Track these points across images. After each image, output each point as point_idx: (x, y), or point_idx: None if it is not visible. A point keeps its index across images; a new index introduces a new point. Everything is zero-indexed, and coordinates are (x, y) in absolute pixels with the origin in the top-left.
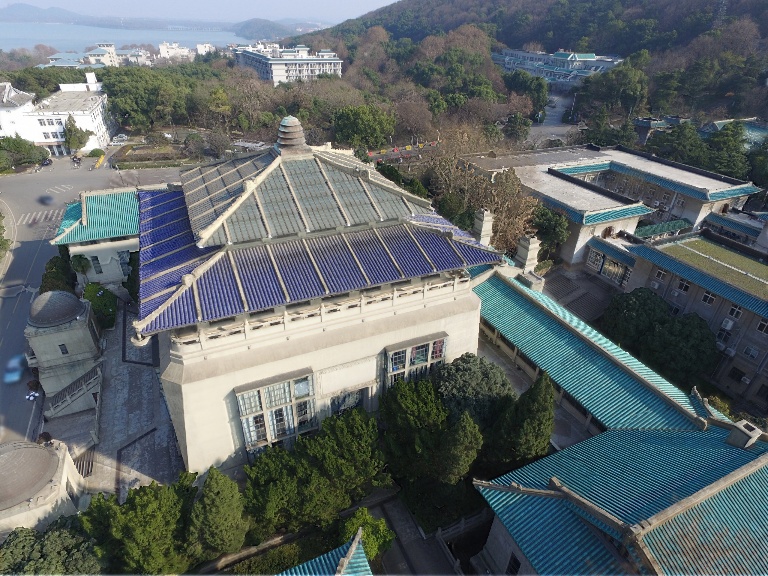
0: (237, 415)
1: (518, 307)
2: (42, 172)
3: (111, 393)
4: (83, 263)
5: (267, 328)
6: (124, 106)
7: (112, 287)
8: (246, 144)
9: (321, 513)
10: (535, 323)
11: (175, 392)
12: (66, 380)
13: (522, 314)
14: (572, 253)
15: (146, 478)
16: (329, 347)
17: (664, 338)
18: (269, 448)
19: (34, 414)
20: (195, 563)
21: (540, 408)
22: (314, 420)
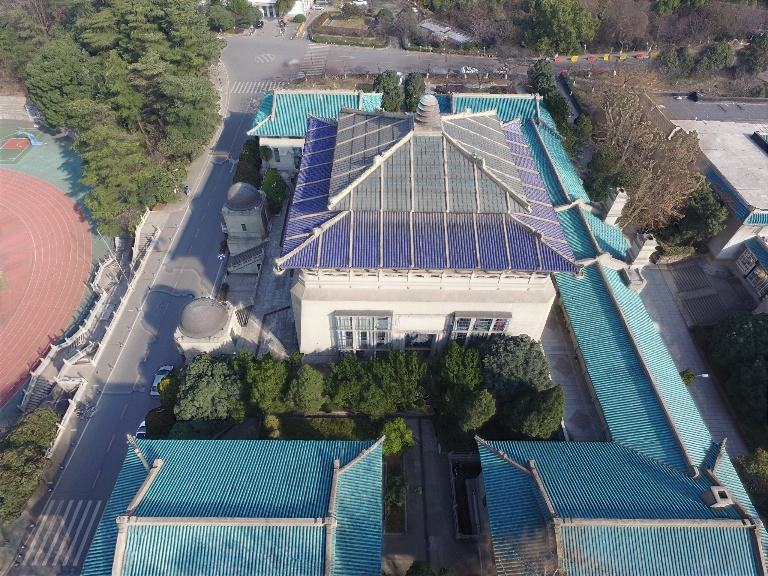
0: (335, 326)
1: (599, 305)
2: (255, 35)
3: (268, 269)
4: (267, 153)
5: (366, 277)
6: None
7: (285, 175)
8: (433, 27)
9: (372, 411)
10: (606, 326)
11: (297, 302)
12: (243, 248)
13: (599, 313)
14: (721, 247)
15: (277, 340)
16: (409, 301)
17: (758, 375)
18: (351, 356)
19: (222, 266)
20: (290, 409)
21: (547, 408)
22: (389, 345)
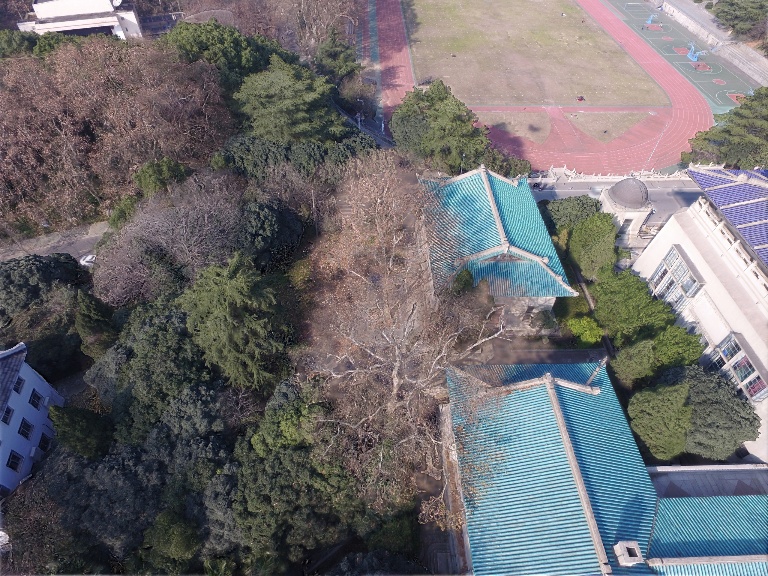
0: None
1: None
2: None
3: None
4: None
5: (725, 238)
6: None
7: None
8: None
9: None
10: None
11: None
12: None
13: None
14: None
15: None
16: (723, 285)
17: None
18: (645, 283)
19: None
20: None
21: None
22: (674, 313)
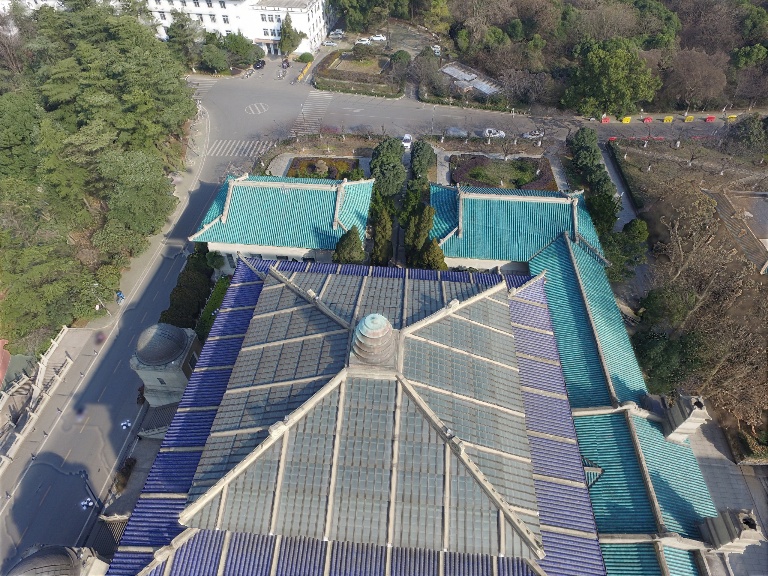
0: None
1: None
2: (252, 78)
3: None
4: (216, 262)
5: None
6: (344, 1)
7: None
8: (456, 73)
9: None
10: None
11: None
12: (165, 401)
13: None
14: None
15: None
16: None
17: None
18: None
19: (135, 424)
20: None
21: None
22: None
